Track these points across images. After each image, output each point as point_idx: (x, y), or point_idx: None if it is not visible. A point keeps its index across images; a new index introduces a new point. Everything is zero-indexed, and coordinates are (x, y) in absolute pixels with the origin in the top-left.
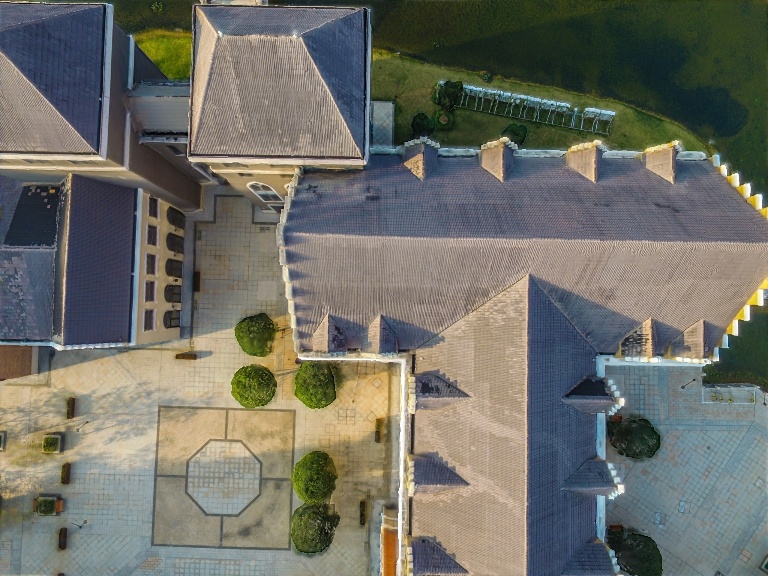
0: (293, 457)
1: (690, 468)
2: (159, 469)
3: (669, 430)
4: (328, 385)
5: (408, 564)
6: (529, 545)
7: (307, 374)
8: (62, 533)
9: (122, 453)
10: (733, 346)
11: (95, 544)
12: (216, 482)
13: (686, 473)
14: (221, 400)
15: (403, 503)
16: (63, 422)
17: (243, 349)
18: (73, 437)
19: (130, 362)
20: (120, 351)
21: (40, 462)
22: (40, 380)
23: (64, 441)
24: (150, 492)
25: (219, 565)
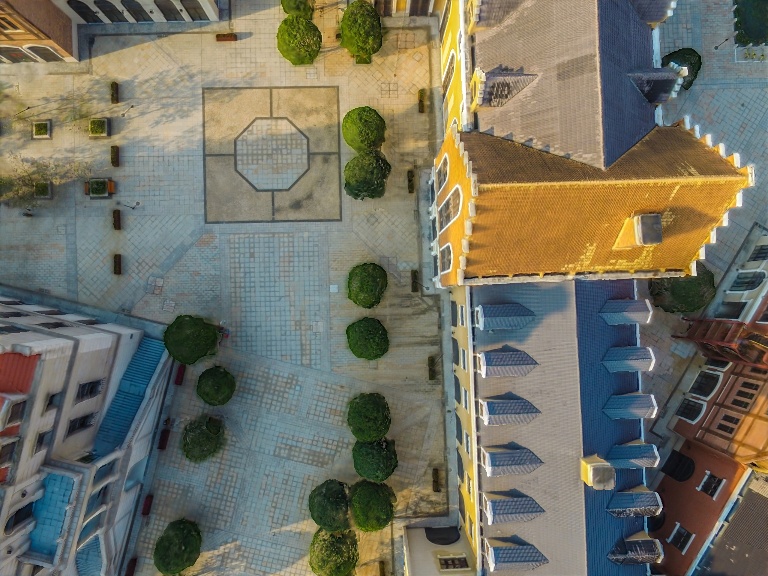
0: (339, 131)
1: (726, 125)
2: (207, 149)
3: (704, 89)
4: (375, 19)
5: (478, 73)
6: (600, 10)
7: (354, 6)
8: (116, 212)
9: (169, 135)
10: (762, 13)
11: (149, 224)
12: (265, 159)
13: (722, 130)
14: (264, 79)
15: (465, 53)
16: (108, 108)
17: (287, 1)
18: (119, 122)
19: (170, 46)
20: (160, 36)
21: (88, 147)
22: (81, 68)
23: (110, 126)
24: (200, 171)
25: (273, 238)
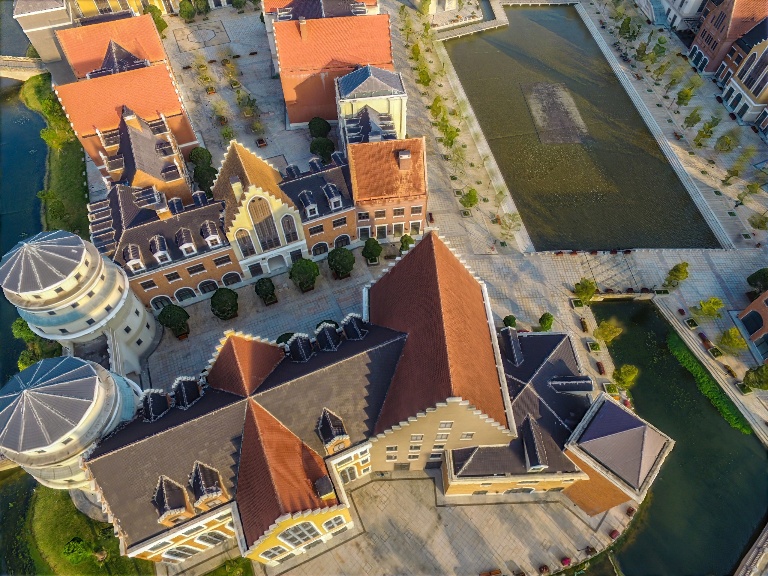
0: None
1: None
2: None
3: None
4: None
5: None
6: None
7: (146, 8)
8: (234, 56)
9: None
10: None
11: None
12: None
13: None
14: None
15: None
16: None
17: None
18: (198, 65)
19: None
20: None
21: (211, 69)
22: (179, 77)
23: None
24: None
25: None
